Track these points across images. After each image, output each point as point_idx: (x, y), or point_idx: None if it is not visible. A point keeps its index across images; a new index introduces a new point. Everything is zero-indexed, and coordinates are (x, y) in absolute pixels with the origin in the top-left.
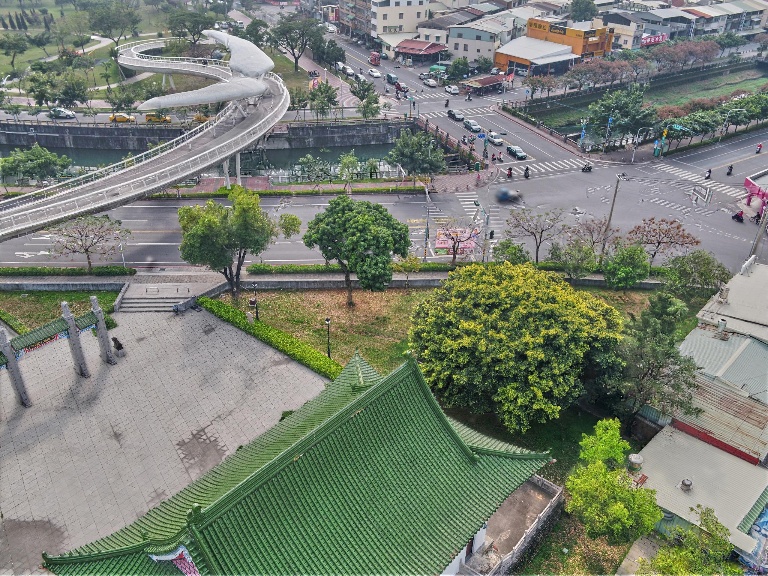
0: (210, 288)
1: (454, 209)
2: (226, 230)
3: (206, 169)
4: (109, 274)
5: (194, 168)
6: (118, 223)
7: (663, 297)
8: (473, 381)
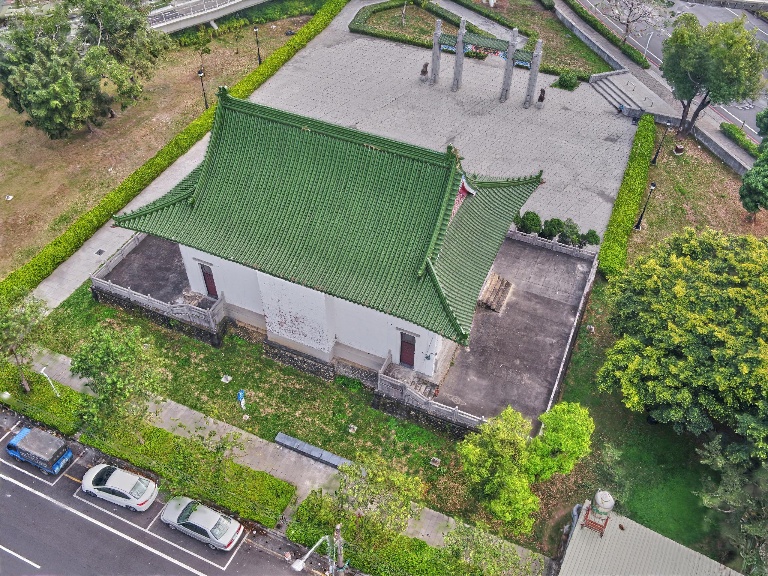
0: (667, 114)
1: None
2: (697, 56)
3: None
4: (629, 56)
5: None
6: (672, 14)
7: None
8: None
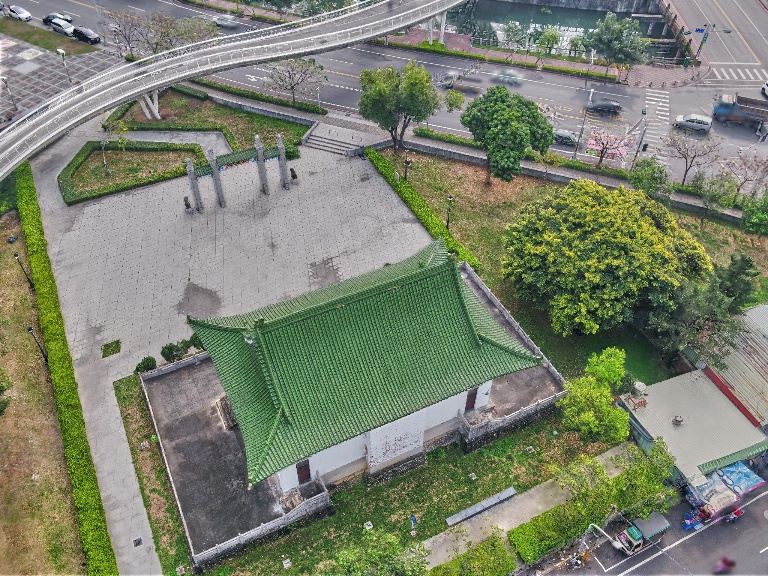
0: (378, 141)
1: (635, 107)
2: (395, 98)
3: (407, 27)
4: (306, 110)
5: (396, 25)
6: (321, 68)
7: (746, 258)
8: (537, 283)
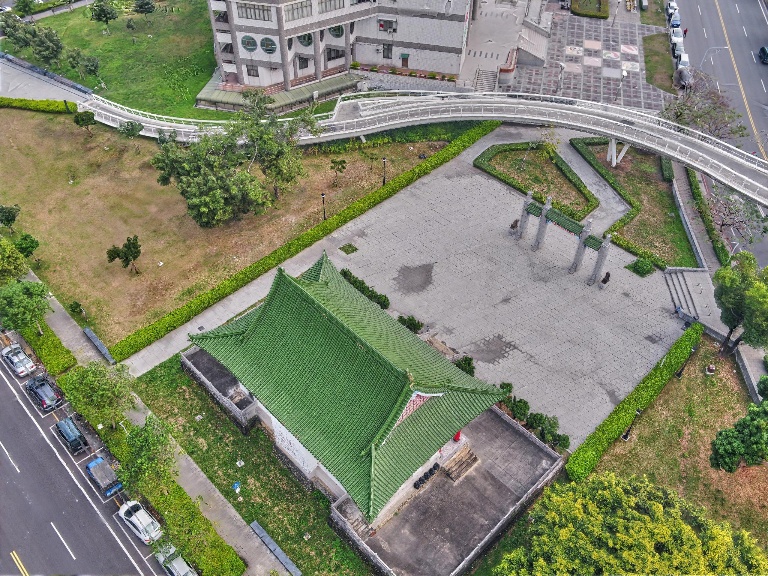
0: (717, 329)
1: None
2: (737, 297)
3: None
4: (717, 255)
5: None
6: (764, 230)
7: None
8: None
